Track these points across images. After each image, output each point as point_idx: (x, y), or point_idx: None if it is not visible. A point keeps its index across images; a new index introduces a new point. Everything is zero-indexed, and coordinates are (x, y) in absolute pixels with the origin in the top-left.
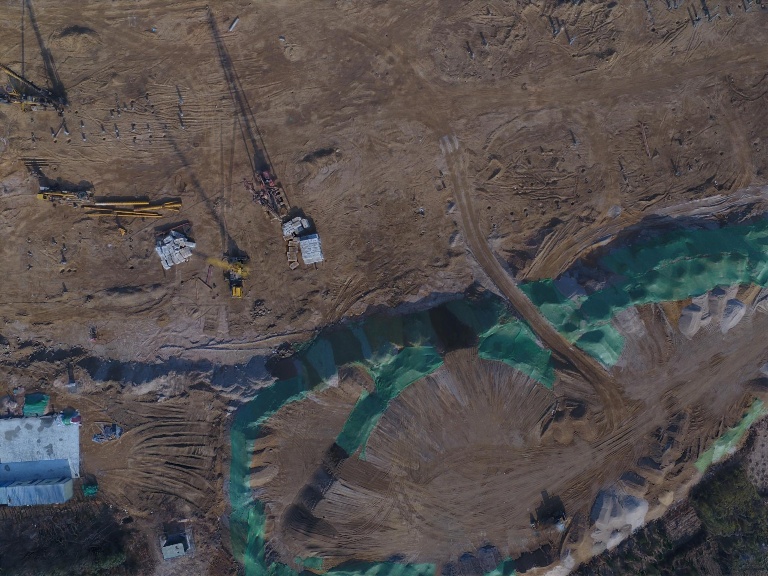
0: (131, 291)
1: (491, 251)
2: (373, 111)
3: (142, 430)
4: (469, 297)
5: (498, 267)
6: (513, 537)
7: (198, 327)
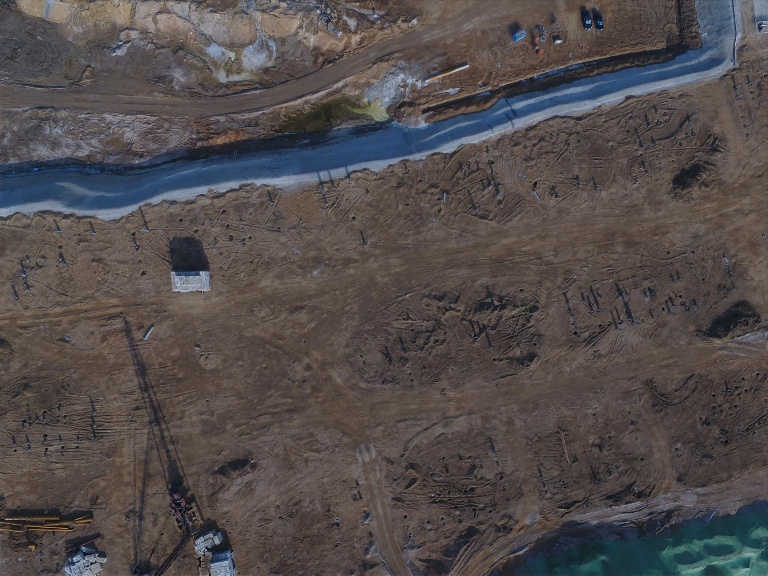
0: None
1: (406, 563)
2: (289, 419)
3: None
4: None
5: None
6: None
7: None
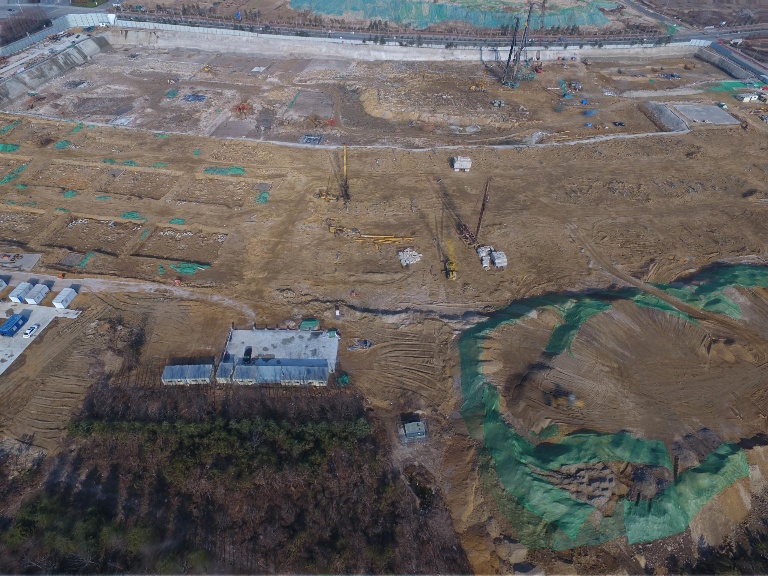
0: (381, 273)
1: (617, 269)
2: (521, 212)
3: (386, 346)
4: (612, 289)
5: (626, 276)
6: (725, 425)
7: (425, 294)
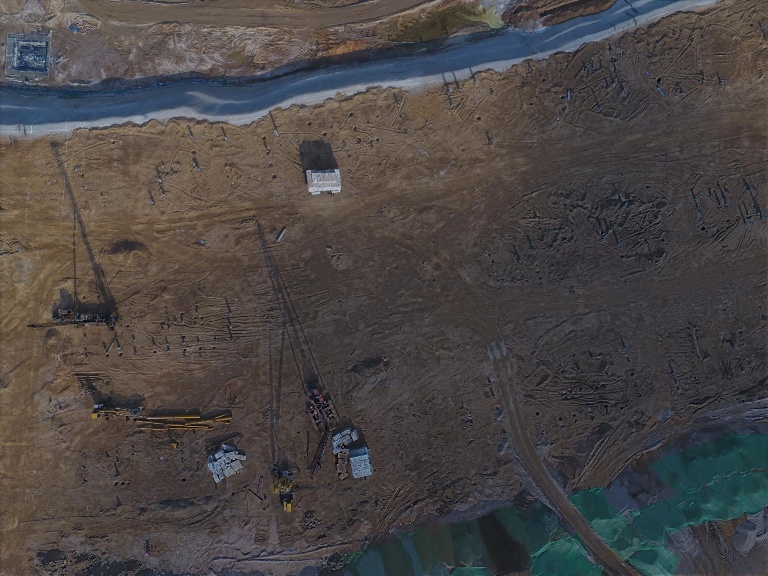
0: (184, 505)
1: (540, 459)
2: (420, 318)
3: None
4: (519, 506)
5: (548, 476)
6: None
7: (249, 538)
